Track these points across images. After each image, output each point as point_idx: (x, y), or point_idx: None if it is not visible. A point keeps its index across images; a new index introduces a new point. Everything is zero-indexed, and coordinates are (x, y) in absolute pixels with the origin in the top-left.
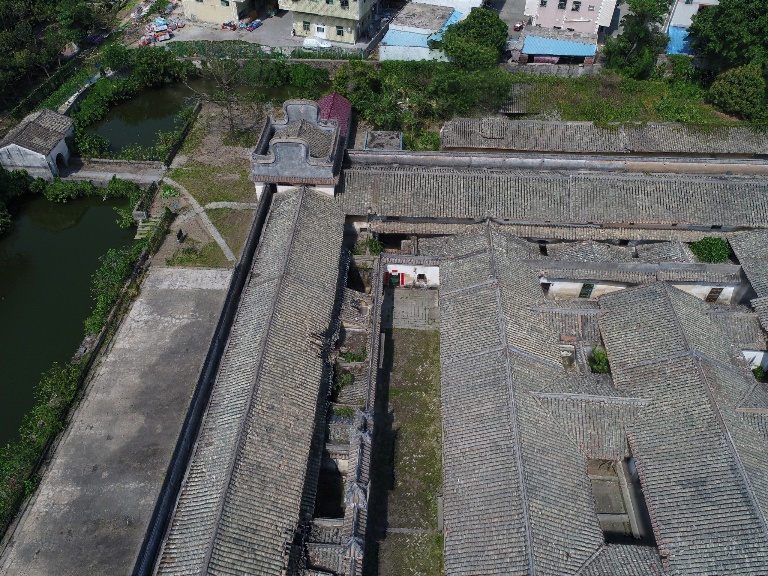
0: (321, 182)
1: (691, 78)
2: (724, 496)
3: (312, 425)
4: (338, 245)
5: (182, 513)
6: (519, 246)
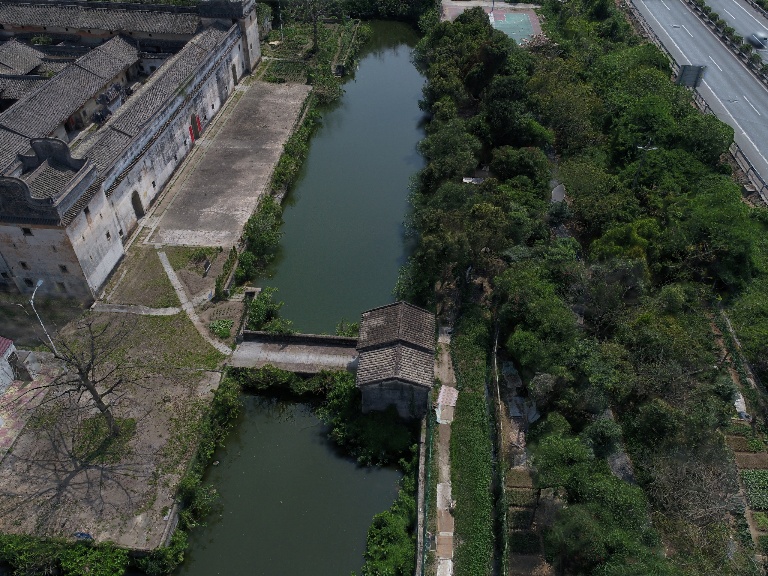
0: None
1: None
2: None
3: None
4: None
5: None
6: None
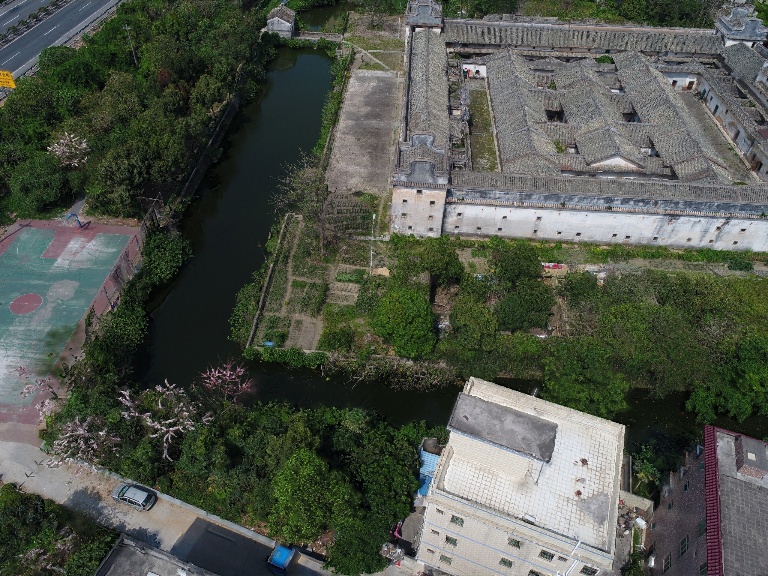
0: (436, 25)
1: (615, 9)
2: None
3: None
4: (445, 49)
5: (413, 98)
6: (521, 58)
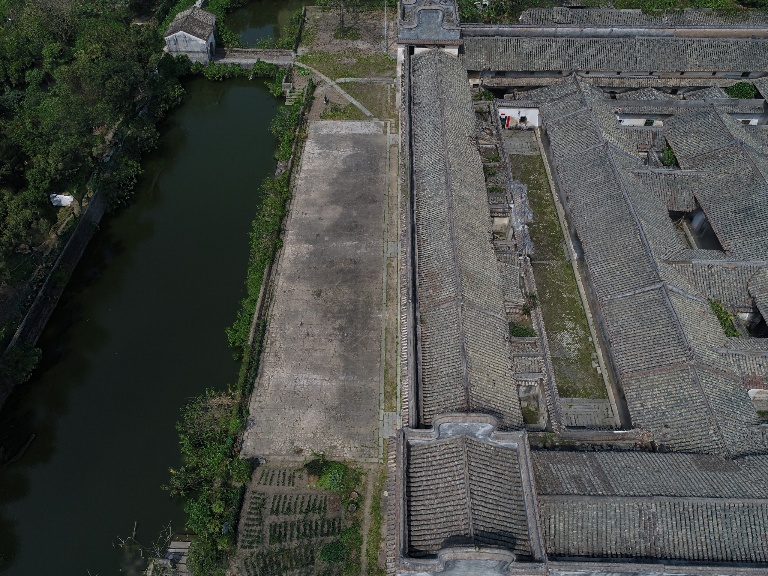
0: (450, 43)
1: None
2: (765, 213)
3: (485, 184)
4: (468, 88)
5: (421, 221)
6: (598, 92)
